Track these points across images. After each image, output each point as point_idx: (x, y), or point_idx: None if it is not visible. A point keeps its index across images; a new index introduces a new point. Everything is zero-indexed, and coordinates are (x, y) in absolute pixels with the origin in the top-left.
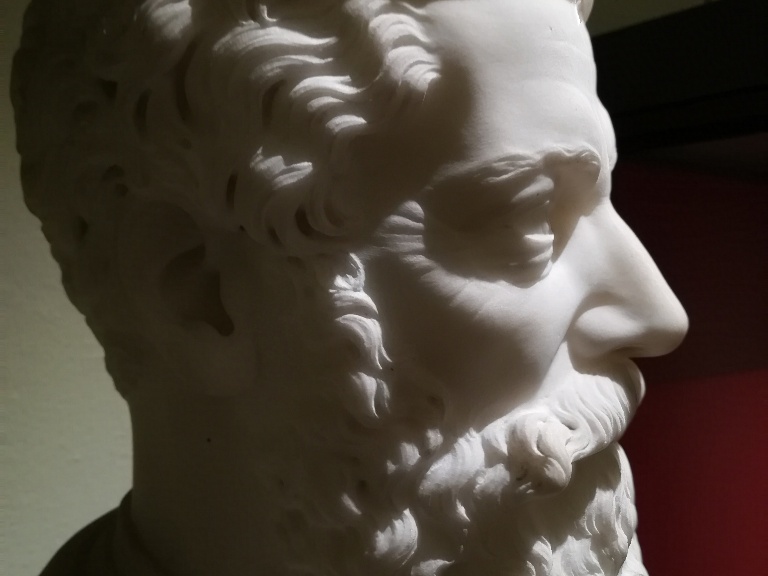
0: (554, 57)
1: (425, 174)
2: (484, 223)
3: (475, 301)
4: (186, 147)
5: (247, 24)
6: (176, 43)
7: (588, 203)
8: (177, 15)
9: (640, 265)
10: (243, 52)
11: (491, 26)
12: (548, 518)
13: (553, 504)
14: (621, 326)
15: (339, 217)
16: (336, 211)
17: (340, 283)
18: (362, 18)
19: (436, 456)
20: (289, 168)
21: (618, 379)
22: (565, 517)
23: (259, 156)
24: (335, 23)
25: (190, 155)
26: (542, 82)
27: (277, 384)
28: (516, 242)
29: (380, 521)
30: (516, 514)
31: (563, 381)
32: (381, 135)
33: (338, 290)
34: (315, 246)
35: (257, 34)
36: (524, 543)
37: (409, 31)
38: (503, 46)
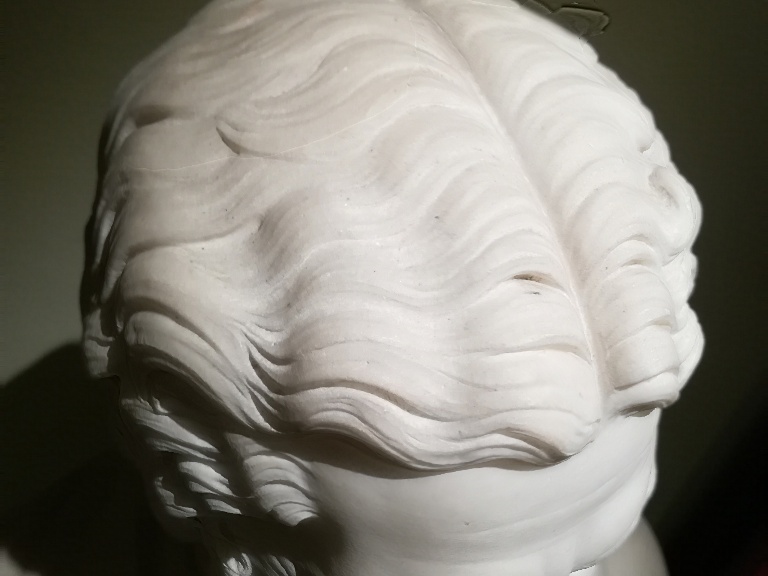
0: (460, 547)
1: (302, 556)
2: None
3: None
4: (120, 433)
5: (144, 403)
6: None
7: None
8: (97, 359)
9: None
10: (139, 423)
11: (380, 508)
12: None
13: None
14: None
15: (232, 534)
16: (230, 530)
17: (232, 565)
18: (238, 453)
19: None
20: (177, 507)
21: None
22: None
23: (159, 482)
24: (218, 439)
25: (122, 440)
26: (430, 565)
27: (209, 558)
28: None
29: None
30: None
31: None
32: None
33: (229, 568)
34: None
35: (150, 416)
36: None
37: (287, 477)
38: (388, 528)
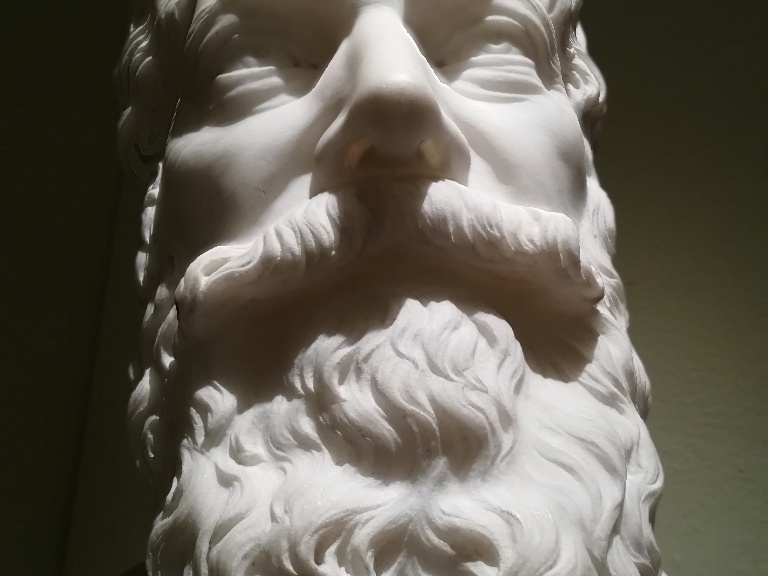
0: None
1: None
2: (195, 84)
3: (177, 152)
4: None
5: None
6: (116, 78)
7: (350, 23)
8: None
9: (362, 50)
10: None
11: None
12: (251, 370)
13: (260, 353)
14: (335, 126)
15: None
16: None
17: None
18: None
19: (168, 312)
20: None
21: (340, 190)
22: (274, 370)
23: None
24: None
25: None
26: None
27: None
28: (213, 86)
29: (138, 383)
30: (193, 355)
31: (287, 212)
32: (165, 62)
33: None
34: (148, 168)
35: None
36: (192, 386)
37: None
38: None
